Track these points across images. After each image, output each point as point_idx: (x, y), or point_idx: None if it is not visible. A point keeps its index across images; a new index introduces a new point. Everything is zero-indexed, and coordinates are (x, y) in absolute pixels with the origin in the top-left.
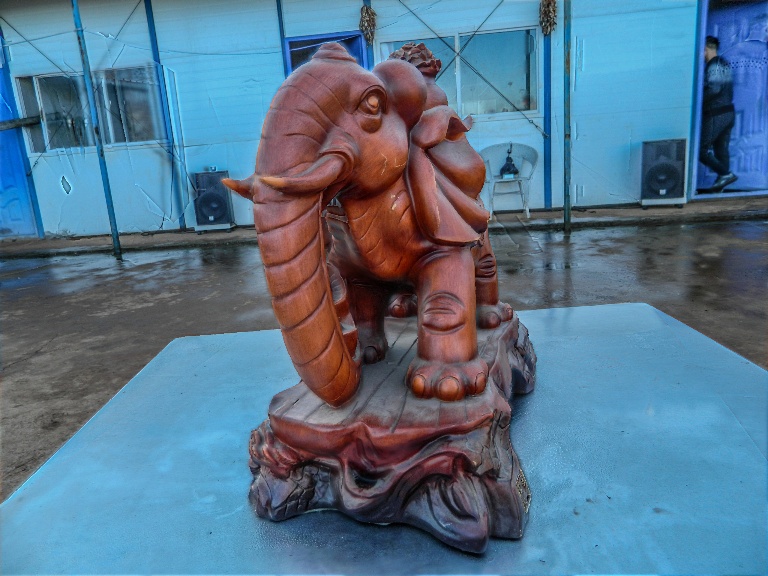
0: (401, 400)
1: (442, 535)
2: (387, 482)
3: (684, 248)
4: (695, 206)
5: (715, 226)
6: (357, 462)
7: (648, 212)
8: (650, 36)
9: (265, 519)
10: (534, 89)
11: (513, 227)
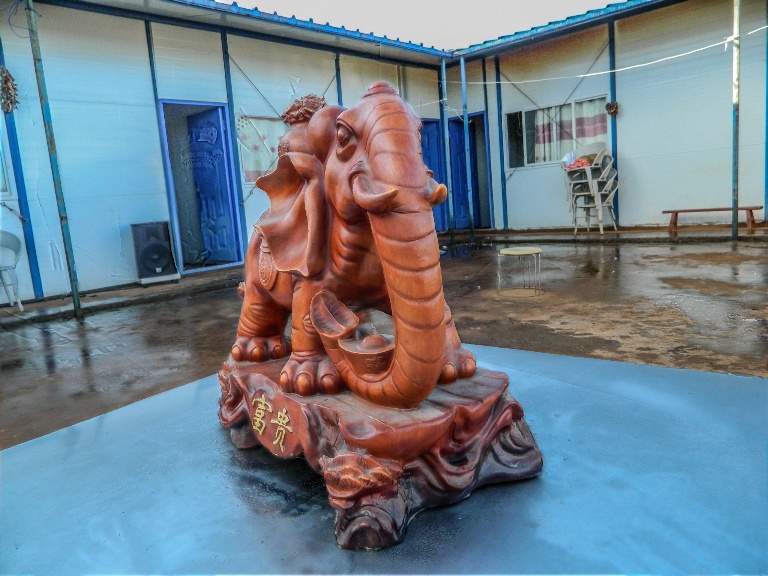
0: (438, 390)
1: (516, 474)
2: (476, 451)
3: (208, 314)
4: (188, 280)
5: (217, 294)
6: (447, 448)
7: (151, 290)
8: (119, 127)
9: (389, 547)
10: (0, 169)
11: (10, 323)
